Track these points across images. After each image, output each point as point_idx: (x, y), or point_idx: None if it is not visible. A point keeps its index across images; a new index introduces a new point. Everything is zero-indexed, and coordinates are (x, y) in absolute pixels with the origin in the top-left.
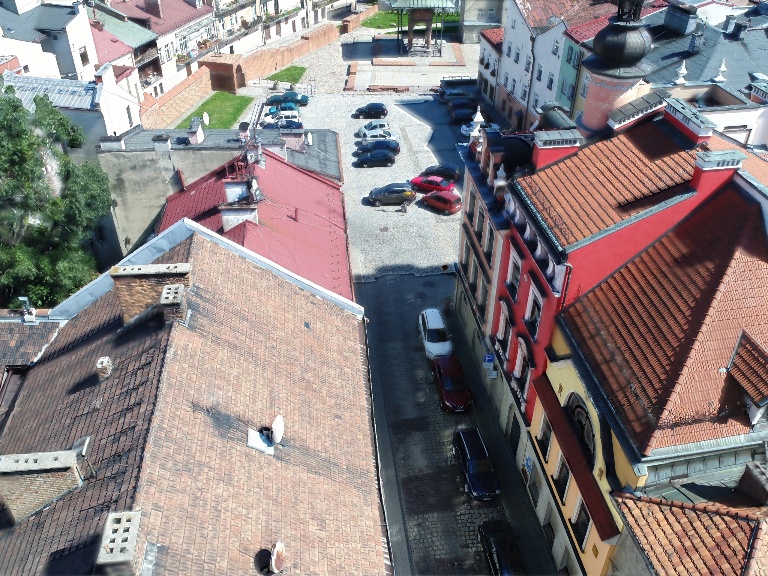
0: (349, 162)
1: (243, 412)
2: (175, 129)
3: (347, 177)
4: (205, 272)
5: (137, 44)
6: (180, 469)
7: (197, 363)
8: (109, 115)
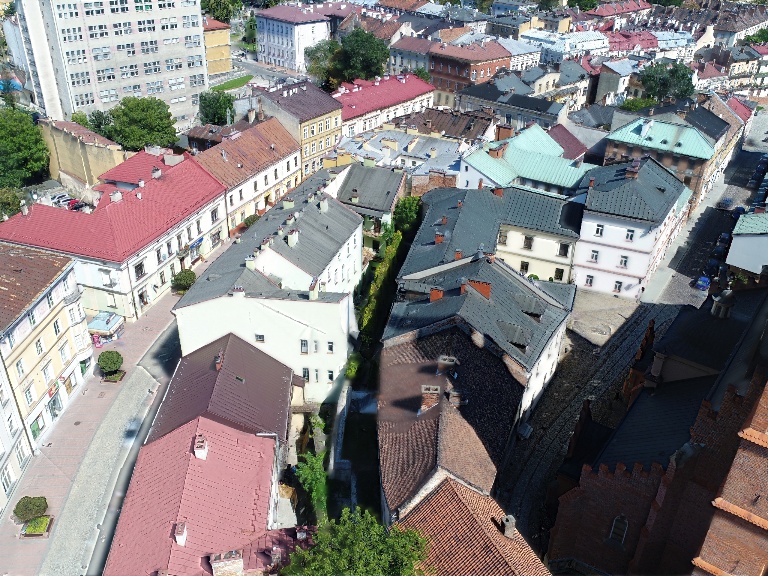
0: (764, 132)
1: (715, 114)
2: None
3: (760, 135)
4: None
5: None
6: None
7: None
8: None
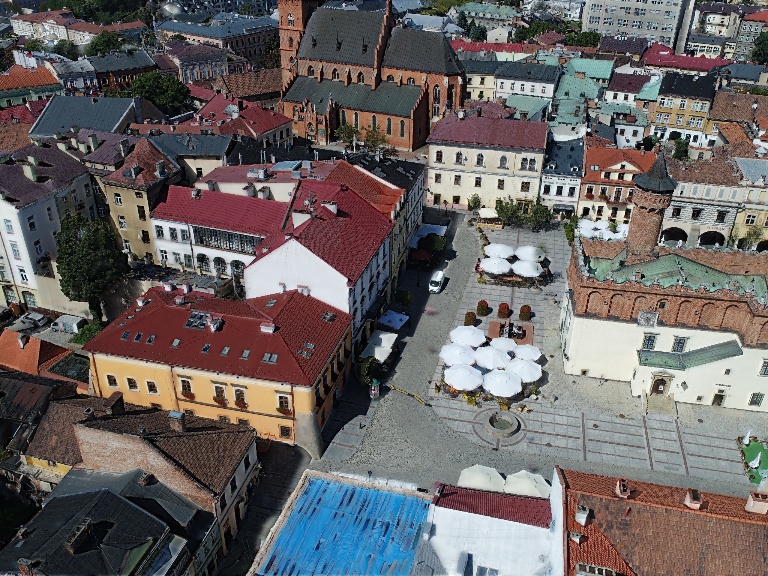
0: None
1: None
2: None
3: None
4: None
5: None
6: (746, 97)
7: (766, 99)
8: None
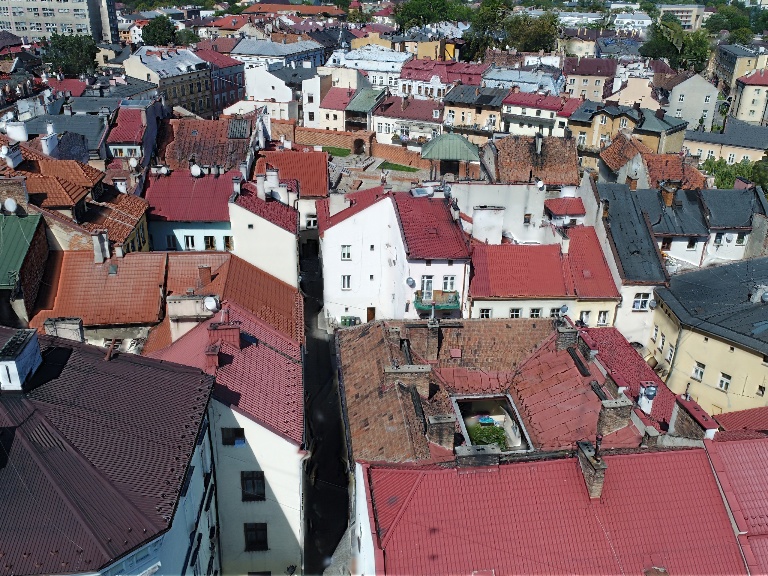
0: None
1: None
2: (152, 88)
3: None
4: (3, 63)
5: (351, 109)
6: None
7: None
8: (130, 68)
